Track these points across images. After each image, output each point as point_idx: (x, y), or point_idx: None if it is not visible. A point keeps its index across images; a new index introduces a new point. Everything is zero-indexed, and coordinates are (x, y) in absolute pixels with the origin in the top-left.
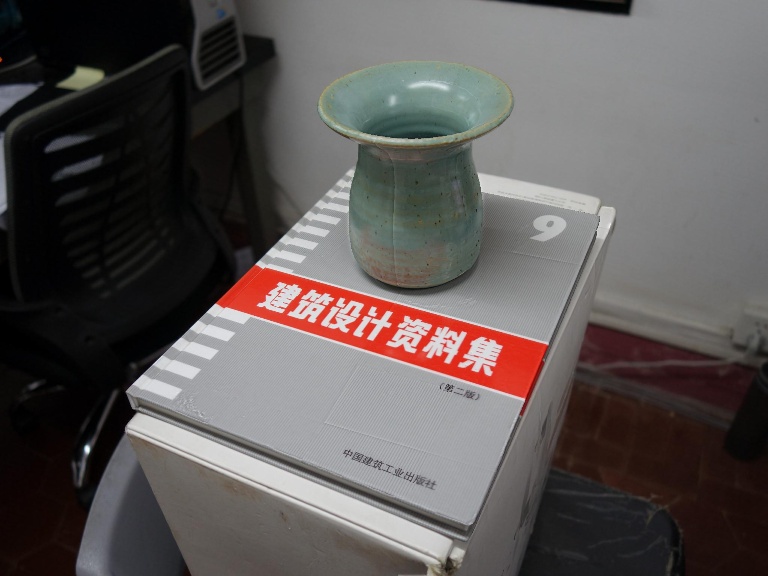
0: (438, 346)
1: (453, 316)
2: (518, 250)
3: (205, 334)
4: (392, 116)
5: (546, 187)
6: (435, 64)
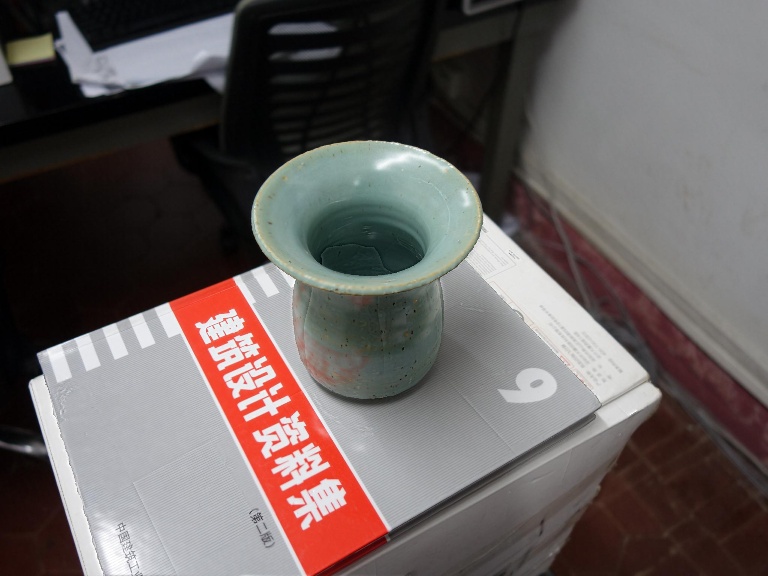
0: (292, 464)
1: (336, 439)
2: (471, 398)
3: (134, 331)
4: (376, 203)
5: (598, 327)
6: (445, 165)
